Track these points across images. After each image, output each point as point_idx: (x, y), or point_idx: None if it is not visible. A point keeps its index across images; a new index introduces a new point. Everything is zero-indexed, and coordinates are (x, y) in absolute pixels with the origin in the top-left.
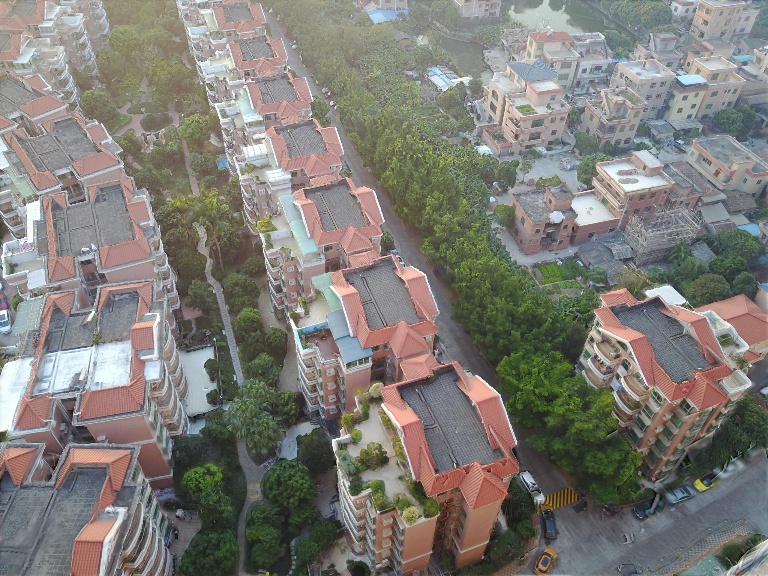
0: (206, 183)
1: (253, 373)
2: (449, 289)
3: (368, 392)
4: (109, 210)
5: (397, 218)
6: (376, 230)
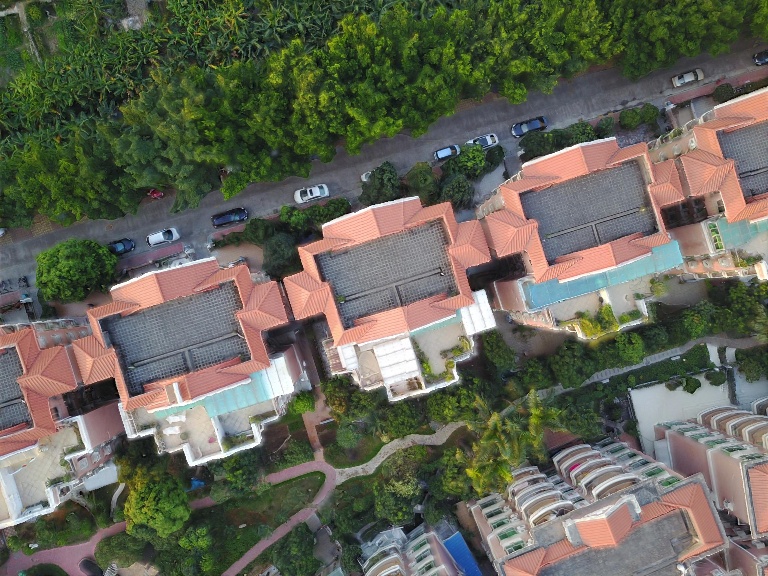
0: (308, 455)
1: None
2: None
3: None
4: (588, 574)
5: None
6: None
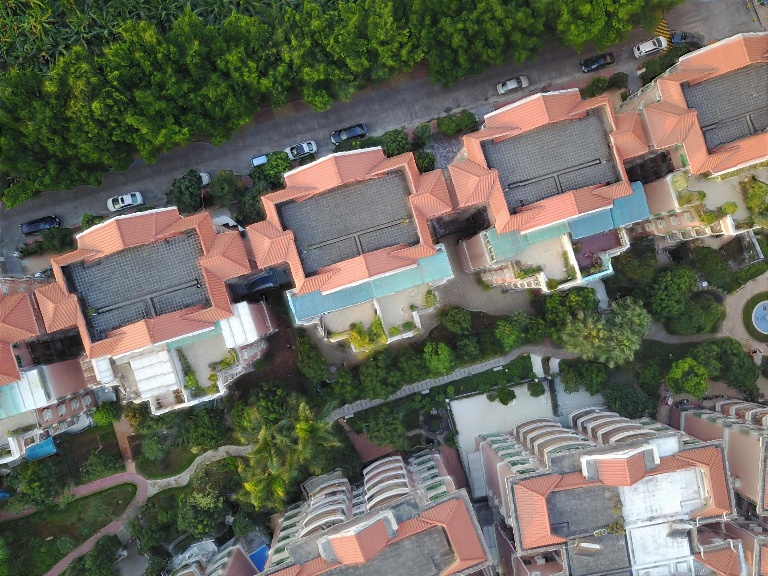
0: (109, 468)
1: (521, 344)
2: (373, 85)
3: (680, 192)
4: None
5: (188, 145)
6: (411, 161)
